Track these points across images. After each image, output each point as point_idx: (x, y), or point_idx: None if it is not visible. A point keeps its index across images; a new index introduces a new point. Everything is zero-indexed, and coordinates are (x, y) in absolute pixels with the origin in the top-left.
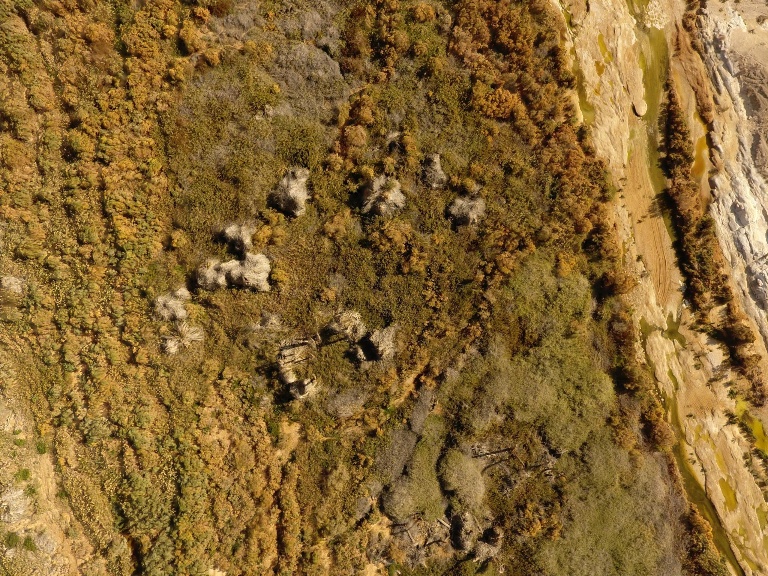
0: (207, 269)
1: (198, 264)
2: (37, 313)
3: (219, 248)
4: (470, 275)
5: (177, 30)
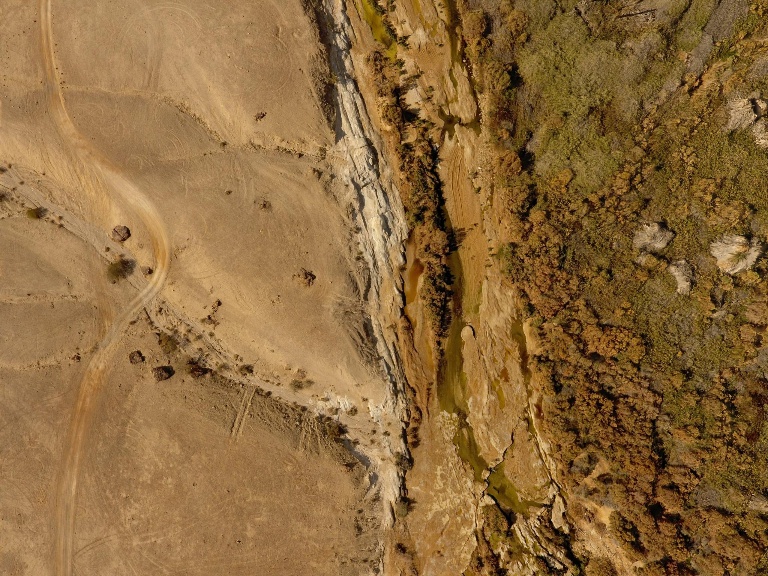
0: None
1: None
2: None
3: None
4: (652, 176)
5: None
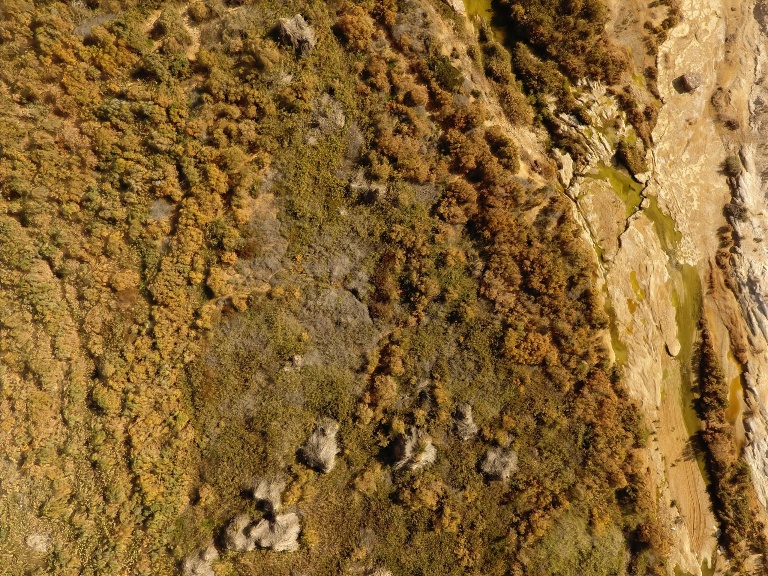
0: (236, 533)
1: (226, 524)
2: (63, 573)
3: (247, 505)
4: (503, 531)
5: (204, 277)
